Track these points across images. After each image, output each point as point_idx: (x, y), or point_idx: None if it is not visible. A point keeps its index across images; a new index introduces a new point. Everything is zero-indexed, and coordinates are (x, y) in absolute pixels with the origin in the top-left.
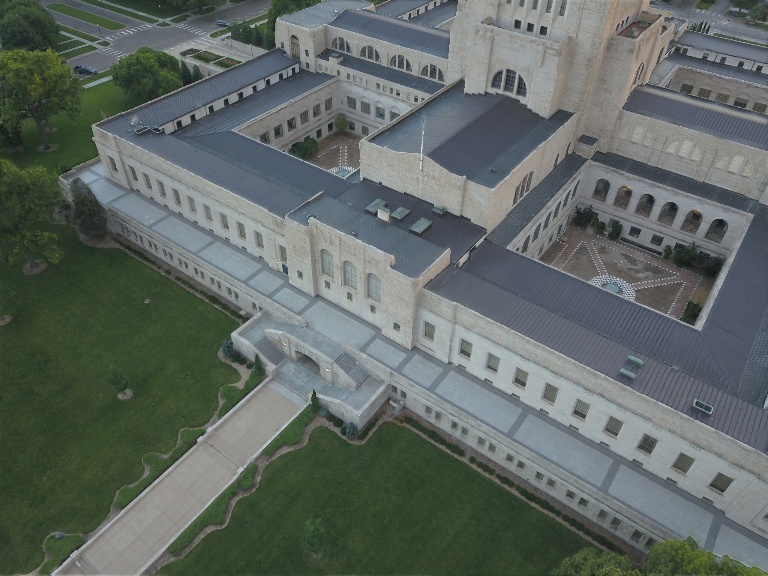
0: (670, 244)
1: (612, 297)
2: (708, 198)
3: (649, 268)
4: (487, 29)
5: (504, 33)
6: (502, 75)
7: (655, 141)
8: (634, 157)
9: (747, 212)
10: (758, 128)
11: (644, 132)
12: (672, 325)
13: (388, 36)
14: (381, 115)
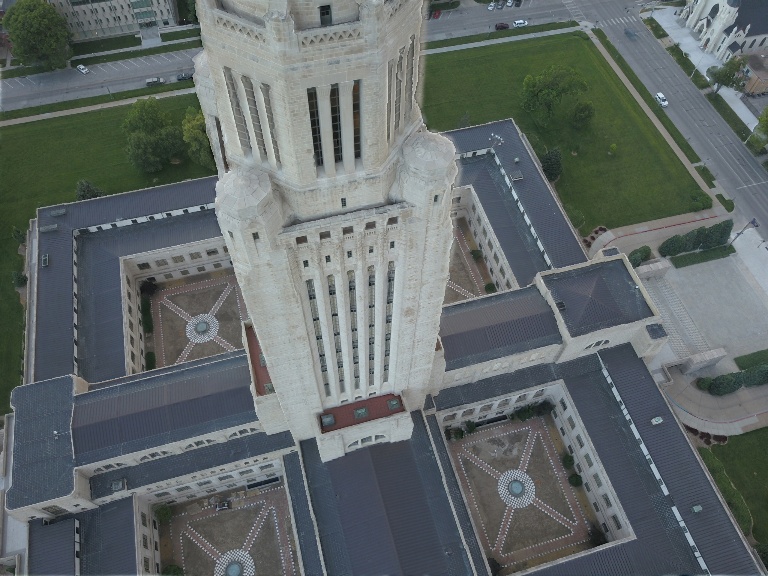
0: (511, 411)
1: (580, 561)
2: (528, 384)
3: (512, 439)
4: (333, 435)
5: (352, 430)
6: (358, 441)
7: (474, 374)
8: (460, 384)
9: (558, 380)
10: (531, 323)
11: (463, 374)
12: (623, 549)
13: (163, 431)
14: (206, 483)
